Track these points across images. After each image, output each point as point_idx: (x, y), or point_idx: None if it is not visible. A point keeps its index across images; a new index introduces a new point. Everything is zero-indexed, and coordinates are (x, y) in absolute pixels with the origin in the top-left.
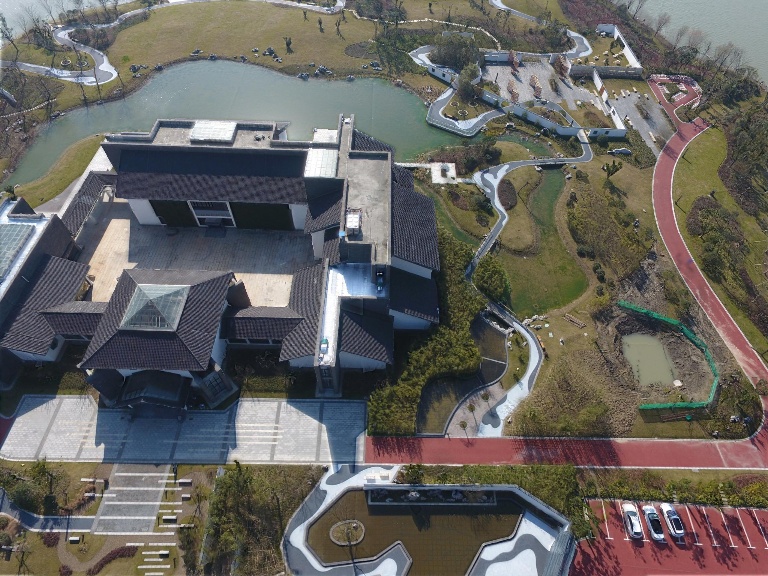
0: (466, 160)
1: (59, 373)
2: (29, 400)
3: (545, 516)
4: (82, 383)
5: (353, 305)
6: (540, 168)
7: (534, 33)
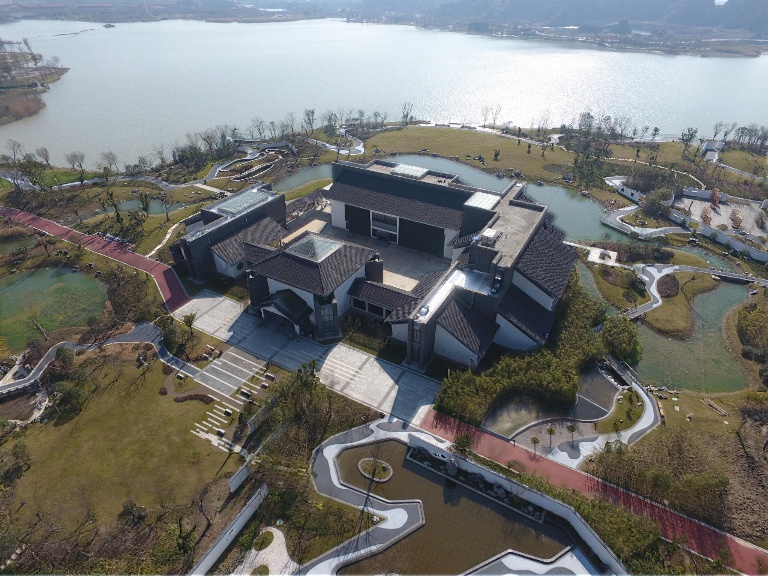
0: None
1: (233, 285)
2: (207, 293)
3: (600, 563)
4: (242, 295)
5: (464, 298)
6: (718, 278)
7: (749, 185)
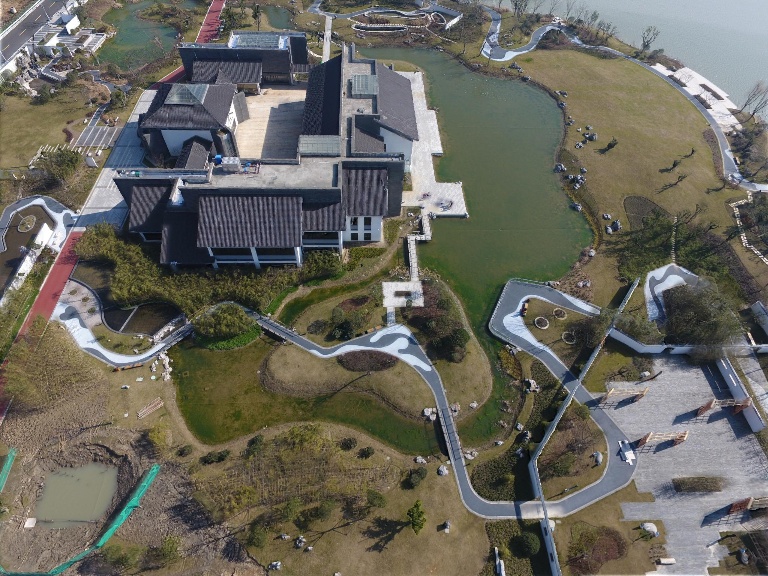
0: (409, 304)
1: None
2: None
3: None
4: None
5: None
6: (432, 416)
7: None
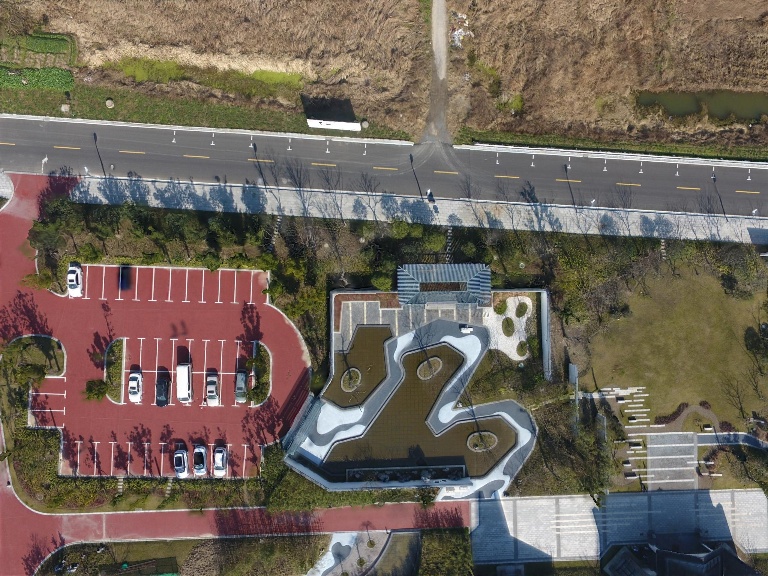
0: None
1: None
2: None
3: (302, 462)
4: (759, 566)
5: None
6: None
7: None
